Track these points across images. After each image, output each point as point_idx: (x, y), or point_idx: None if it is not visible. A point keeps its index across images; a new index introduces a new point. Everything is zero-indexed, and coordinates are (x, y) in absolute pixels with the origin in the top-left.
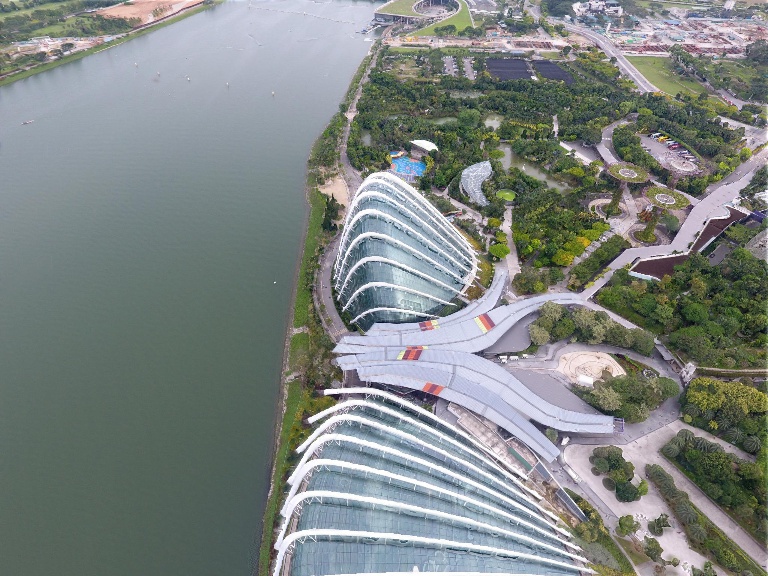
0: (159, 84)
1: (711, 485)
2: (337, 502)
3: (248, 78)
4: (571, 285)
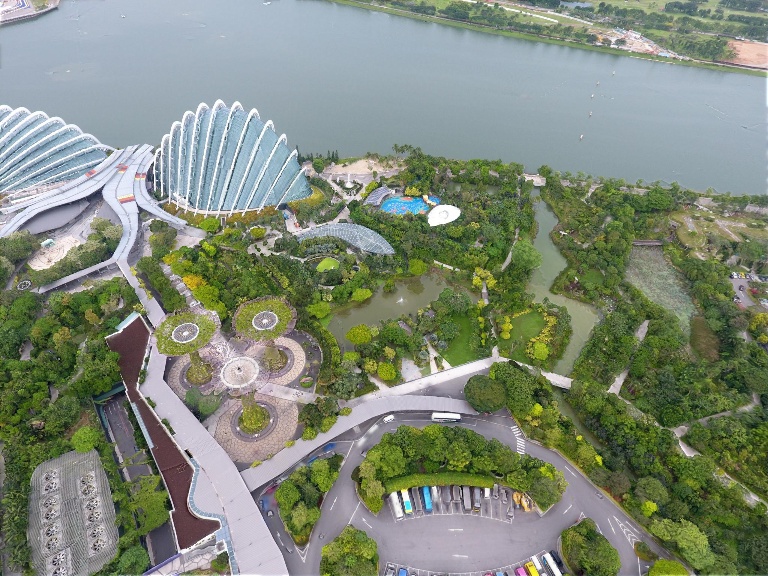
0: (575, 87)
1: None
2: None
3: (623, 125)
4: None
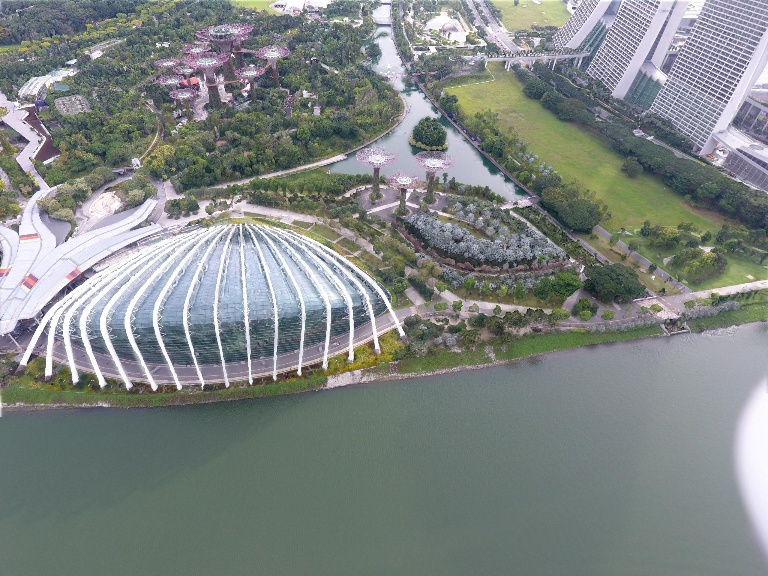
0: None
1: (203, 180)
2: (142, 301)
3: None
4: (27, 194)
